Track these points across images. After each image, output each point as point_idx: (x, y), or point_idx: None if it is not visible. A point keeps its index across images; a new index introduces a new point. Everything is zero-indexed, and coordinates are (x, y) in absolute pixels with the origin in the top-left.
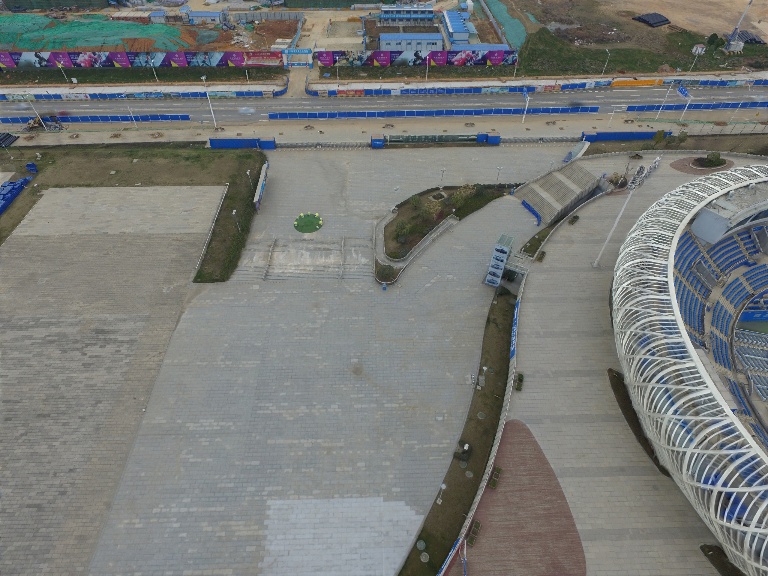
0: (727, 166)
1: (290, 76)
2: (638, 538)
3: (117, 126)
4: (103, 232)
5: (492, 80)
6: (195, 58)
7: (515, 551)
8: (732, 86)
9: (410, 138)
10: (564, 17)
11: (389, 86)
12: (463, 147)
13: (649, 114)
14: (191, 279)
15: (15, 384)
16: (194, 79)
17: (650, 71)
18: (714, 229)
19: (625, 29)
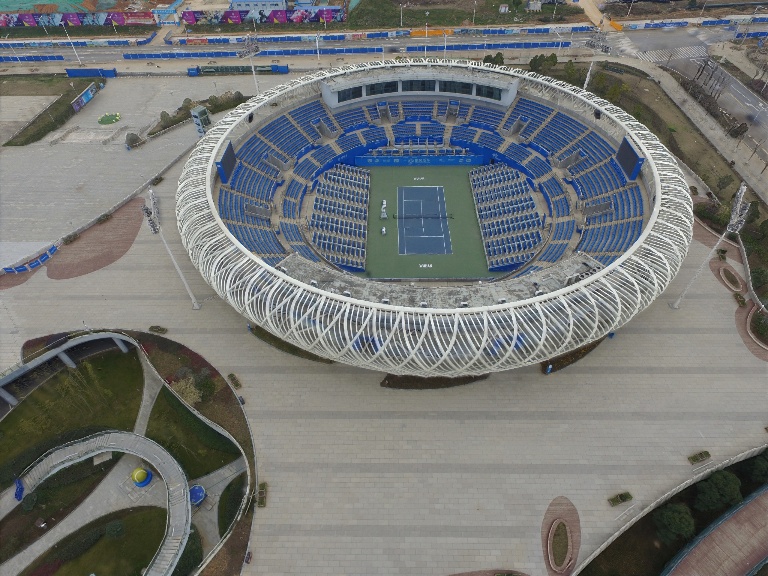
0: None
1: (159, 32)
2: (167, 243)
3: (9, 65)
4: None
5: None
6: (86, 18)
7: (90, 247)
8: (510, 34)
9: (219, 69)
10: None
11: None
12: (259, 75)
13: None
14: (1, 144)
15: None
16: (84, 34)
17: (452, 25)
18: (329, 96)
19: None
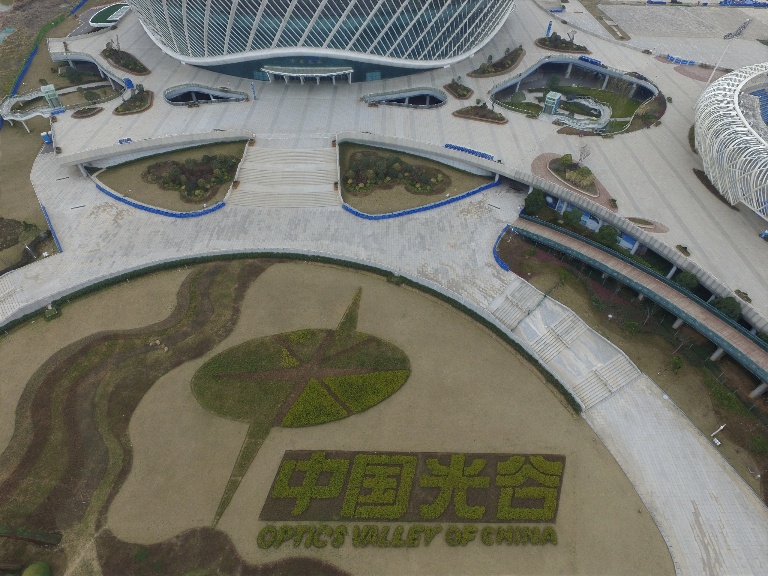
0: None
1: None
2: None
3: None
4: (761, 21)
5: None
6: None
7: None
8: None
9: None
10: None
11: None
12: None
13: None
14: (757, 39)
15: None
16: None
17: None
18: None
19: None
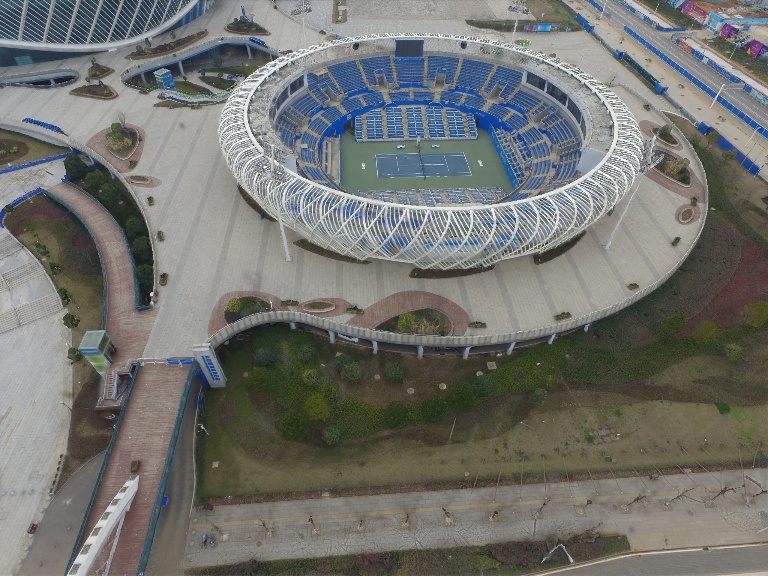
0: (668, 145)
1: (693, 31)
2: None
3: (581, 1)
4: (488, 3)
5: None
6: None
7: None
8: None
9: None
10: None
11: (720, 62)
12: (642, 82)
13: None
14: (467, 19)
15: (410, 3)
16: (655, 8)
17: None
18: None
19: None
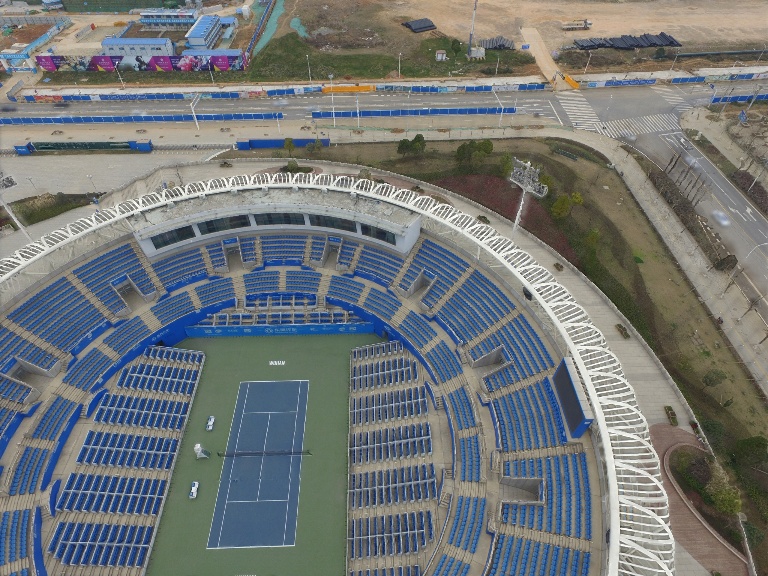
0: None
1: (8, 81)
2: None
3: None
4: None
5: (210, 86)
6: None
7: None
8: (444, 92)
9: (59, 145)
10: (335, 22)
11: (101, 92)
12: (112, 154)
13: (335, 121)
14: None
15: None
16: None
17: (377, 77)
18: None
19: (386, 34)
